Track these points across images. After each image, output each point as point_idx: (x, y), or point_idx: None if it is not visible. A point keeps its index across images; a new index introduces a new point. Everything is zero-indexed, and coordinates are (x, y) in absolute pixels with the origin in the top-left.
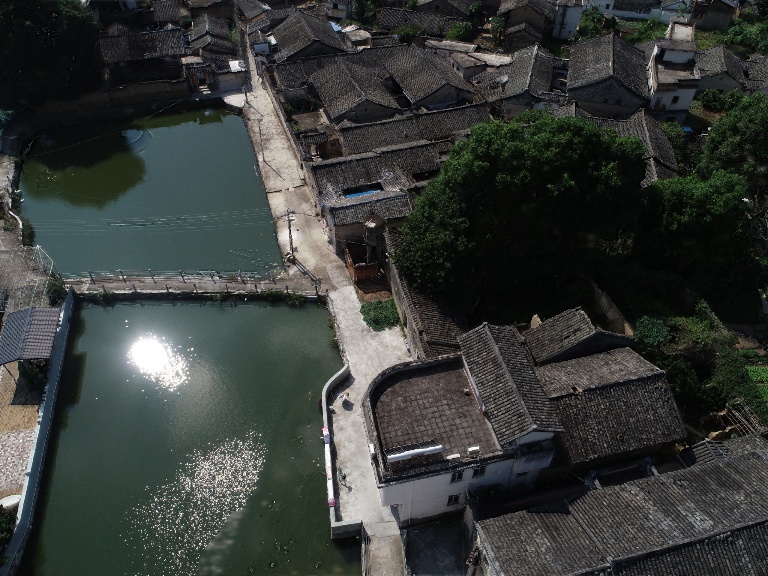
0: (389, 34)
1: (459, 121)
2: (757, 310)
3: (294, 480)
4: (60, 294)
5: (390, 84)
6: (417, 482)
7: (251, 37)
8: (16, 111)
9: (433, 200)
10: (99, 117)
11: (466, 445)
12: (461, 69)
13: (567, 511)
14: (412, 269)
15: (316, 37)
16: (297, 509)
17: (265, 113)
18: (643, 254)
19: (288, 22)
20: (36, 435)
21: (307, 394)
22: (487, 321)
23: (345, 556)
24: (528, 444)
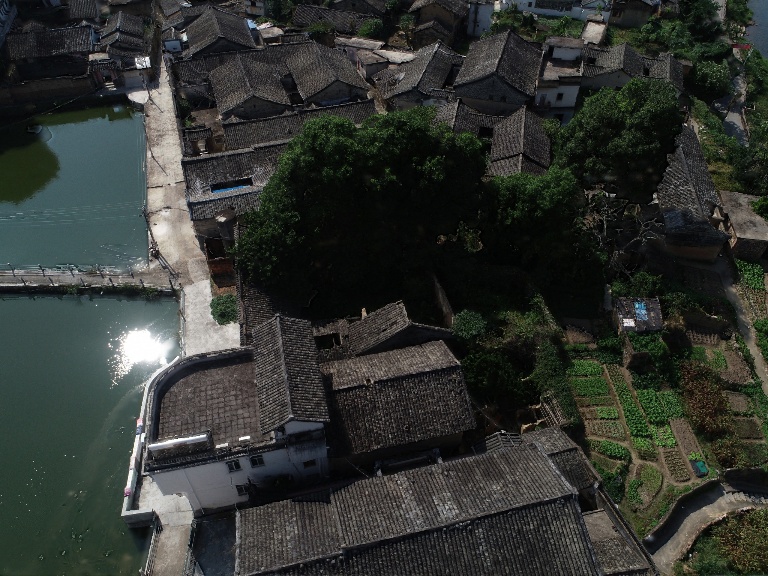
0: (301, 31)
1: None
2: (598, 305)
3: (106, 470)
4: None
5: (290, 81)
6: (189, 471)
7: (164, 34)
8: None
9: (270, 194)
10: None
11: (241, 435)
12: (364, 66)
13: (329, 500)
14: (246, 263)
15: (223, 34)
16: (102, 499)
17: (165, 109)
18: None
19: (201, 19)
20: None
21: (140, 386)
22: (332, 315)
23: (138, 545)
24: (298, 434)
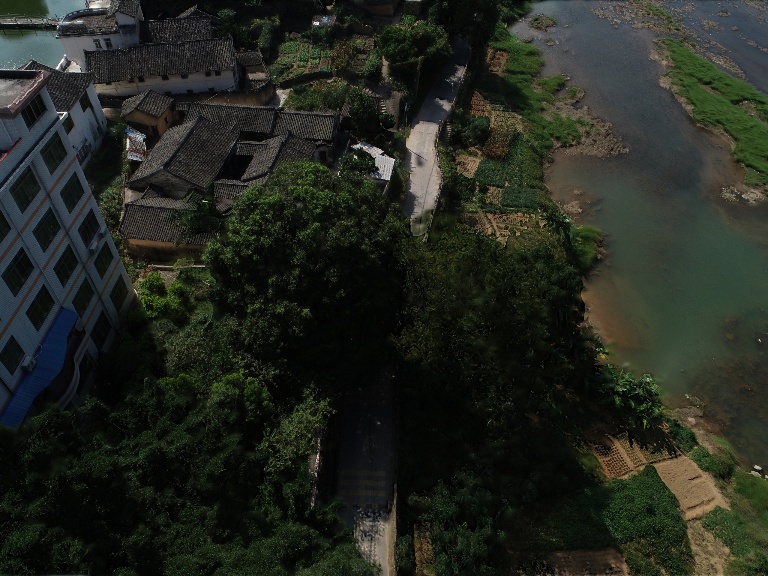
0: None
1: None
2: None
3: None
4: None
5: None
6: (77, 42)
7: None
8: None
9: None
10: None
11: None
12: None
13: None
14: None
15: None
16: None
17: None
18: (264, 2)
19: None
20: None
21: None
22: None
23: None
24: (124, 26)
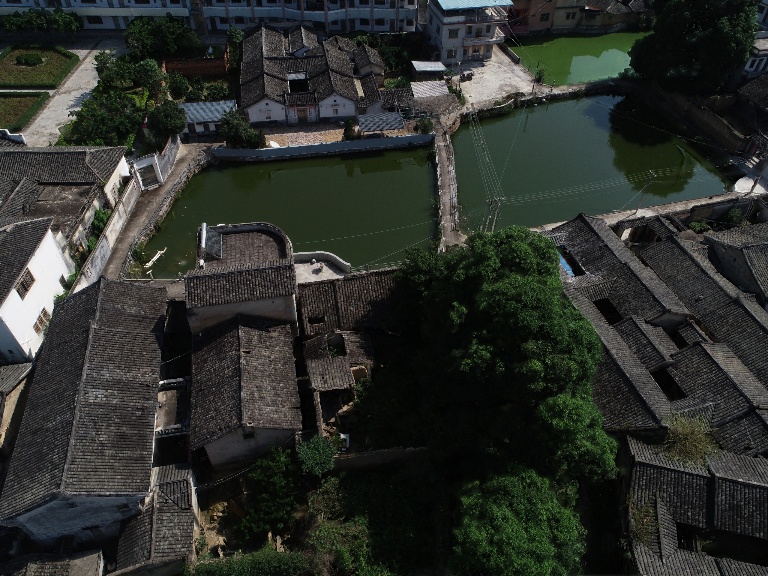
0: None
1: (761, 354)
2: None
3: None
4: (424, 130)
5: None
6: None
7: None
8: (640, 73)
9: None
10: (664, 114)
11: None
12: None
13: None
14: None
15: None
16: None
17: None
18: None
19: None
20: (313, 144)
21: None
22: (403, 370)
23: None
24: None
